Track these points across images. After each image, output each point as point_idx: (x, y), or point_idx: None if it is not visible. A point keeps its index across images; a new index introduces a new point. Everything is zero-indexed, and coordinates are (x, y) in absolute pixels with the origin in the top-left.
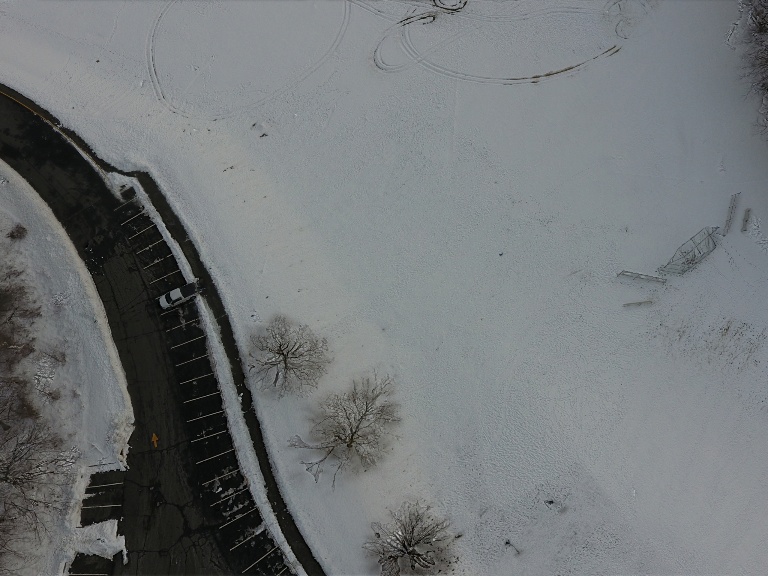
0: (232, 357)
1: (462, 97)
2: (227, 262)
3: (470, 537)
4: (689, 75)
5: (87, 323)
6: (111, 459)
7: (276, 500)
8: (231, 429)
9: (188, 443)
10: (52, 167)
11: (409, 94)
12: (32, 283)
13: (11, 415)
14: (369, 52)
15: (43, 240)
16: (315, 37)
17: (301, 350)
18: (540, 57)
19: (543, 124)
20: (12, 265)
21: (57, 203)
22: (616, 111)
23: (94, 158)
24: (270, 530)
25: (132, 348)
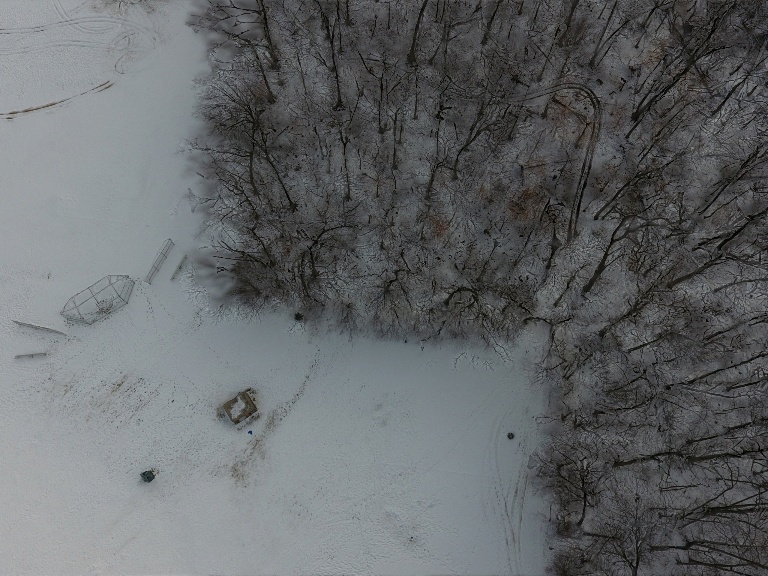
0: None
1: None
2: None
3: None
4: (175, 113)
5: None
6: None
7: None
8: None
9: None
10: None
11: None
12: None
13: None
14: None
15: None
16: None
17: None
18: (25, 92)
19: (2, 162)
20: None
21: None
22: (84, 150)
23: None
24: None
25: None
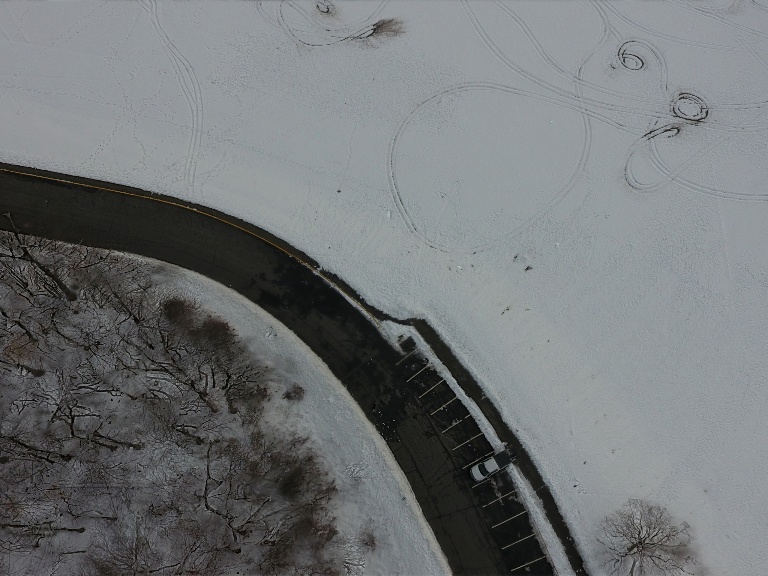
0: (563, 537)
1: (726, 217)
2: (533, 423)
3: None
4: None
5: (393, 500)
6: None
7: None
8: None
9: None
10: (319, 316)
11: (671, 216)
12: (320, 452)
13: None
14: (619, 170)
15: (325, 401)
16: (560, 156)
17: (660, 536)
18: None
19: None
20: (295, 431)
21: (332, 358)
22: None
23: (363, 305)
24: None
25: (448, 528)
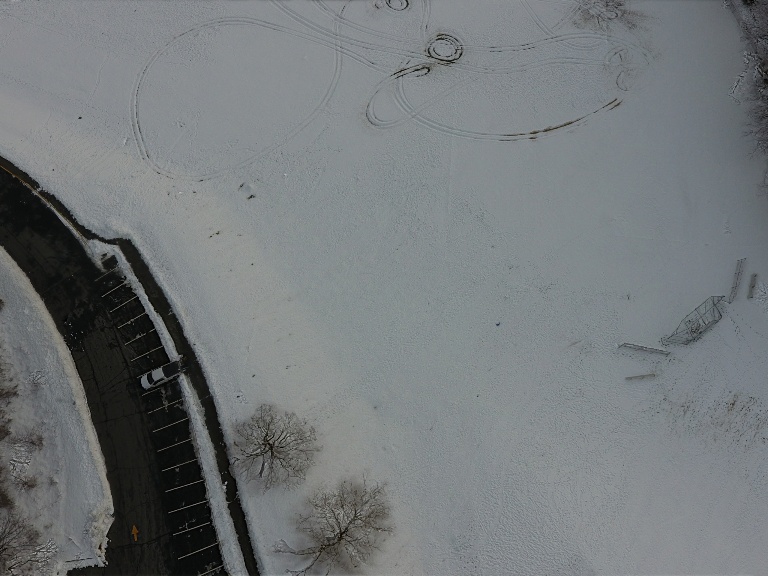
0: (216, 442)
1: (458, 155)
2: (212, 338)
3: None
4: (693, 130)
5: (65, 404)
6: (89, 554)
7: None
8: (215, 521)
9: (170, 536)
10: (31, 234)
11: (403, 152)
12: (9, 359)
13: None
14: (361, 107)
15: (20, 313)
16: (305, 91)
17: (288, 439)
18: (538, 111)
19: (541, 183)
20: None
21: (35, 273)
22: (617, 169)
23: (74, 224)
24: None
25: (112, 431)
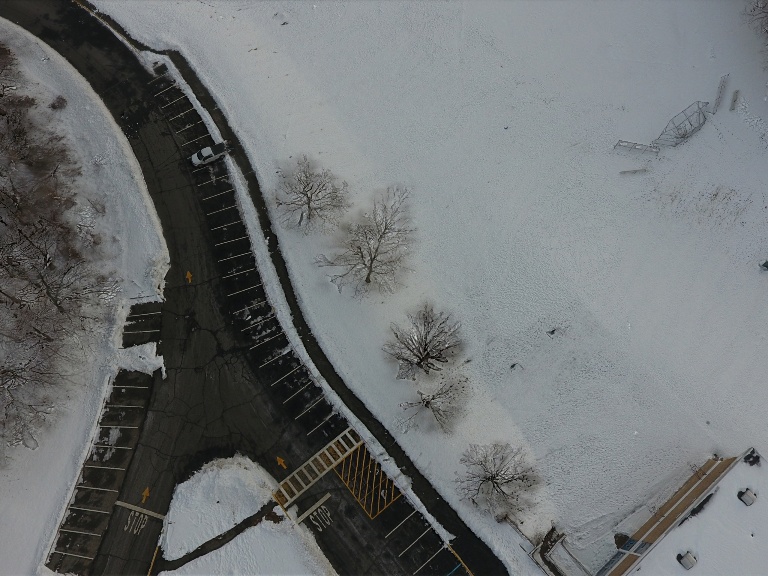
0: (259, 207)
1: None
2: (253, 127)
3: (478, 362)
4: None
5: (125, 179)
6: (149, 292)
7: (301, 325)
8: (259, 267)
9: (220, 279)
10: (89, 47)
11: None
12: (73, 147)
13: (57, 255)
14: None
15: (82, 109)
16: None
17: (324, 192)
18: None
19: (545, 16)
20: (54, 131)
21: (95, 78)
22: (614, 5)
23: (128, 39)
24: (296, 350)
25: (167, 200)
